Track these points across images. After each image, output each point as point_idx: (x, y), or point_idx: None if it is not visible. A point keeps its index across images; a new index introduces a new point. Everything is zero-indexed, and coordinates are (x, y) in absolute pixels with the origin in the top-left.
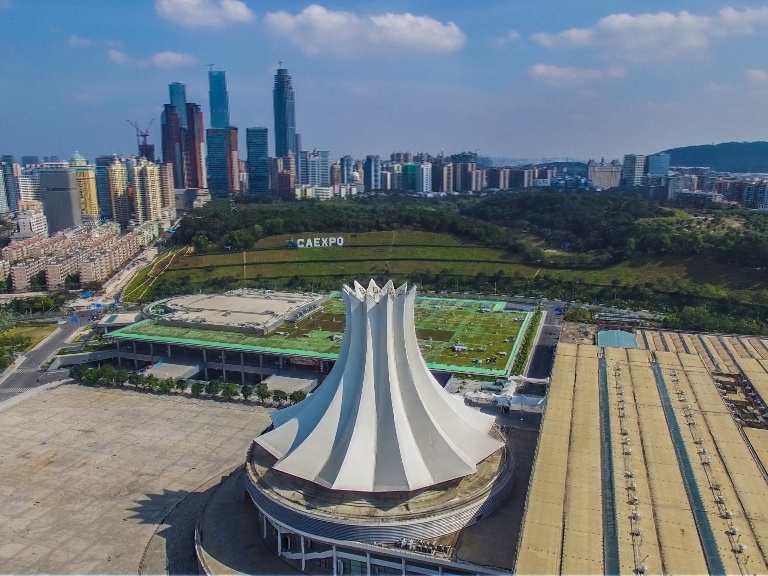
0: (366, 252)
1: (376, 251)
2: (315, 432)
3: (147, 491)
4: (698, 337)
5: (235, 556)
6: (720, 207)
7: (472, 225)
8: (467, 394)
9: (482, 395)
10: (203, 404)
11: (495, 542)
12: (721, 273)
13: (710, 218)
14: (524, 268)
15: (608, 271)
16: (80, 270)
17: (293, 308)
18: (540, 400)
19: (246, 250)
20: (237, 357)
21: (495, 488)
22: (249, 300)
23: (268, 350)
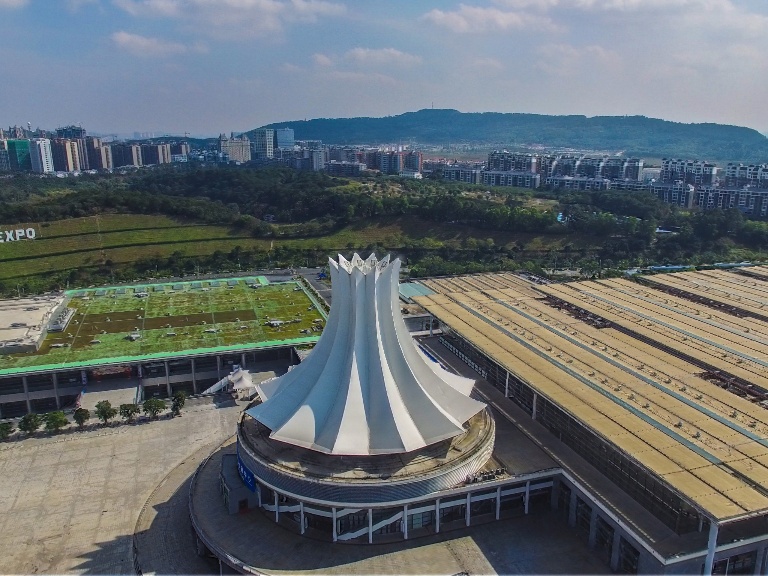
0: (70, 243)
1: (82, 240)
2: (347, 410)
3: (74, 553)
4: (460, 279)
5: (296, 559)
6: (369, 175)
7: (188, 203)
8: None
9: None
10: (25, 445)
11: (522, 455)
12: (429, 228)
13: (378, 184)
14: (257, 242)
15: (336, 236)
16: None
17: (46, 315)
18: None
19: None
20: (10, 385)
21: (492, 416)
22: None
23: (67, 366)
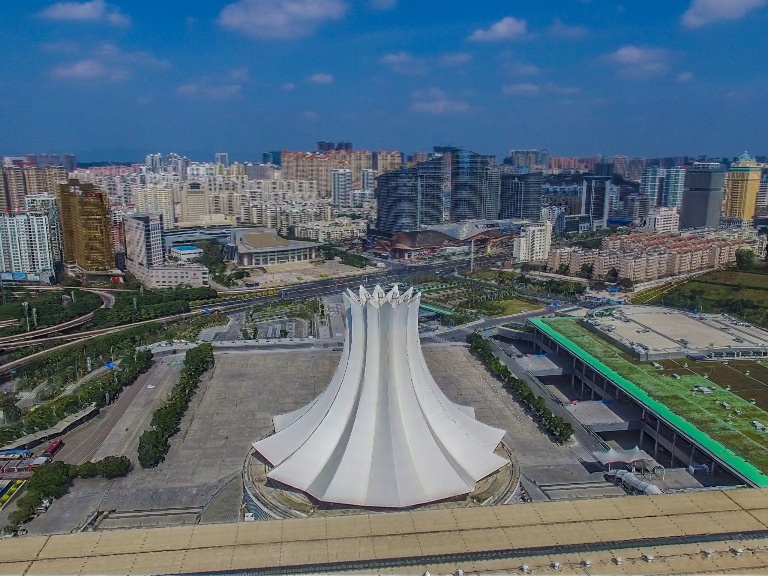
0: None
1: None
2: (308, 405)
3: None
4: None
5: None
6: None
7: None
8: None
9: None
10: (501, 396)
11: None
12: None
13: None
14: None
15: None
16: (620, 265)
17: (717, 346)
18: None
19: None
20: None
21: None
22: (698, 326)
23: (606, 373)
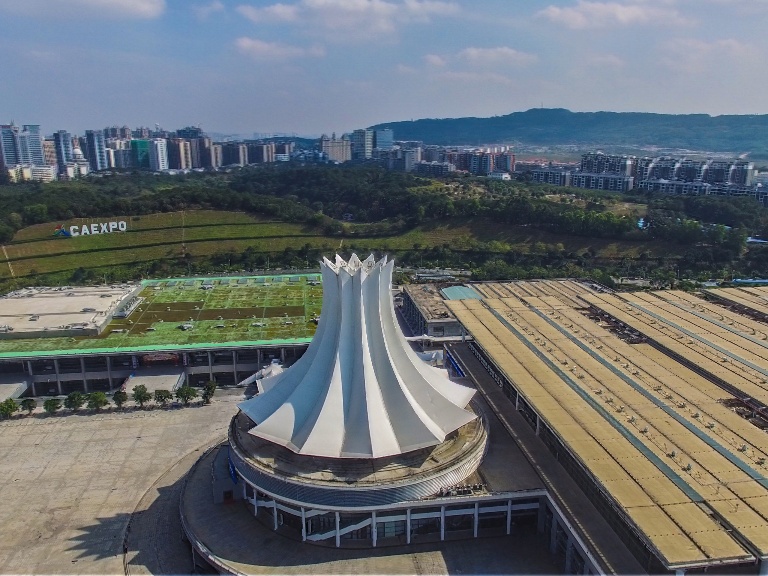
0: (156, 236)
1: (167, 234)
2: (324, 411)
3: (76, 525)
4: (516, 285)
5: (260, 554)
6: (457, 176)
7: (266, 201)
8: None
9: None
10: (68, 421)
11: (510, 471)
12: (499, 231)
13: (461, 185)
14: (328, 240)
15: (405, 237)
16: None
17: (115, 302)
18: (433, 354)
19: (4, 244)
20: (71, 364)
21: (487, 428)
22: (49, 300)
23: (119, 350)
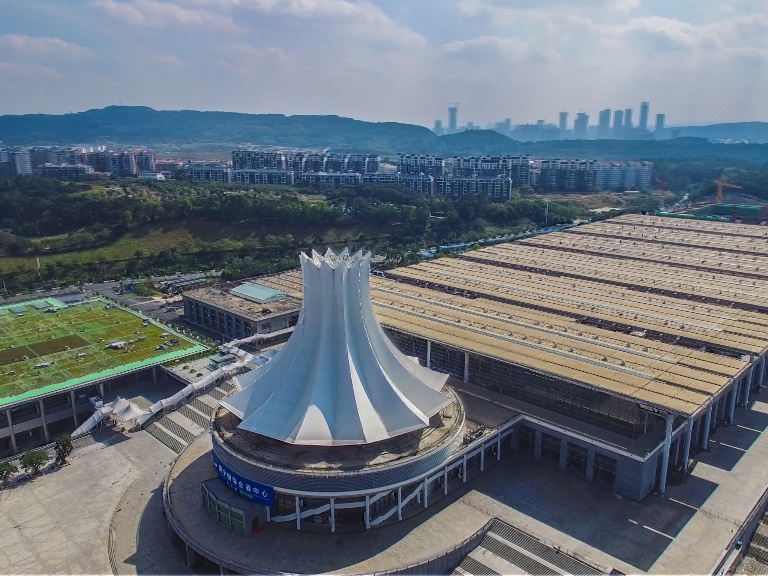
0: None
1: None
2: (358, 401)
3: None
4: (288, 275)
5: (348, 554)
6: (100, 178)
7: None
8: (224, 369)
9: (237, 365)
10: None
11: (484, 411)
12: (220, 229)
13: (127, 188)
14: (17, 260)
15: (116, 246)
16: None
17: None
18: None
19: None
20: None
21: None
22: None
23: None
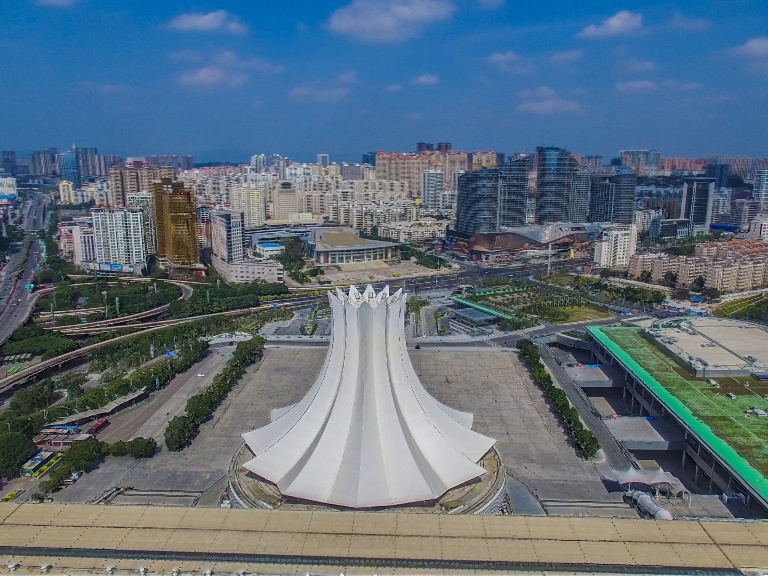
0: None
1: None
2: None
3: None
4: None
5: None
6: None
7: None
8: None
9: None
10: (537, 405)
11: None
12: None
13: None
14: None
15: None
16: (706, 274)
17: None
18: None
19: None
20: None
21: None
22: None
23: (652, 388)
